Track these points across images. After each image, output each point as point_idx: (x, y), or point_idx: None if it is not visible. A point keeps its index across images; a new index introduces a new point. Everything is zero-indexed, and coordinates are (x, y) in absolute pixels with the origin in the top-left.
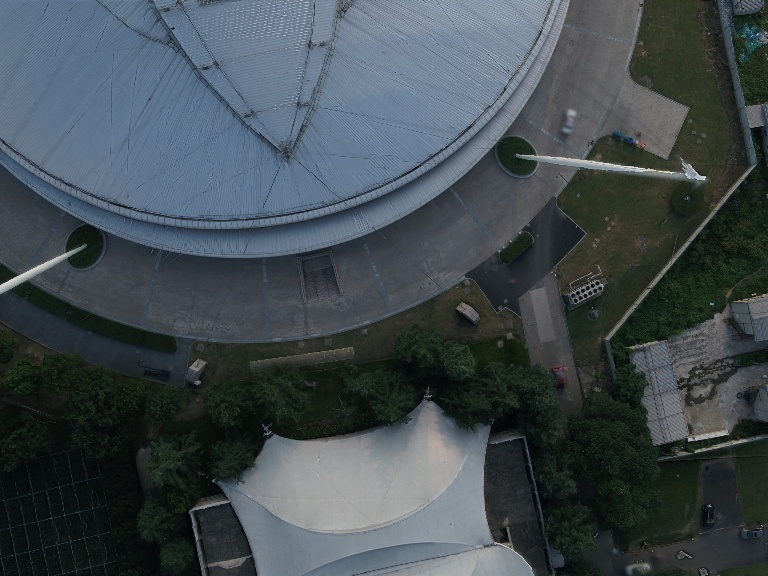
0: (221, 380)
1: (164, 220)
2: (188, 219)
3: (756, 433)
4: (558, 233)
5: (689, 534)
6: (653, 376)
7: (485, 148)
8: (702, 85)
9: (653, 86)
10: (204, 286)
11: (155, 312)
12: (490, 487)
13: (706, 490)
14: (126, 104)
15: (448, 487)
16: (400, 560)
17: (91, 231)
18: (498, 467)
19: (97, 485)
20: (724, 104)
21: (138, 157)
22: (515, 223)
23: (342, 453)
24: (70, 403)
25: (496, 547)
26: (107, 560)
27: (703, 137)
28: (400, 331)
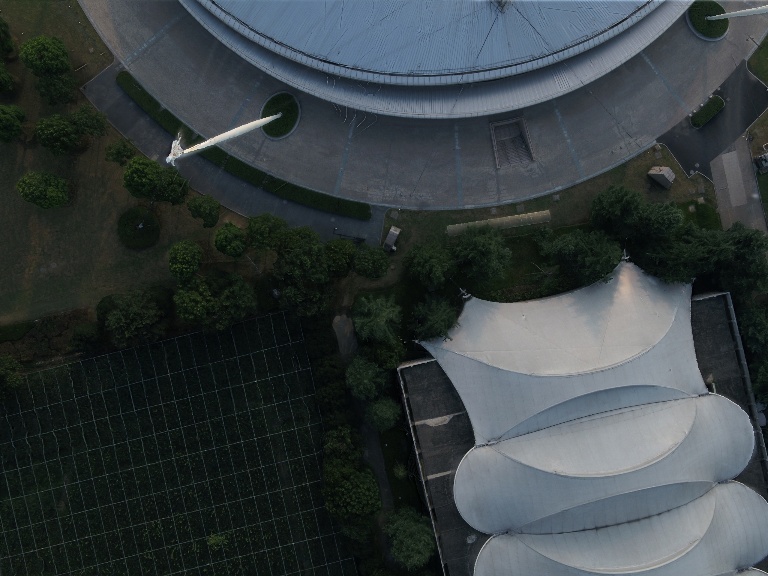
0: None
1: (373, 77)
2: (397, 75)
3: None
4: (749, 96)
5: None
6: None
7: (685, 5)
8: None
9: None
10: (397, 154)
11: (349, 180)
12: (694, 344)
13: None
14: None
15: (666, 334)
16: (624, 403)
17: (287, 99)
18: (701, 324)
19: (298, 349)
20: None
21: (353, 10)
22: (706, 87)
23: (546, 311)
24: (282, 260)
25: (711, 396)
26: (311, 422)
27: None
28: None
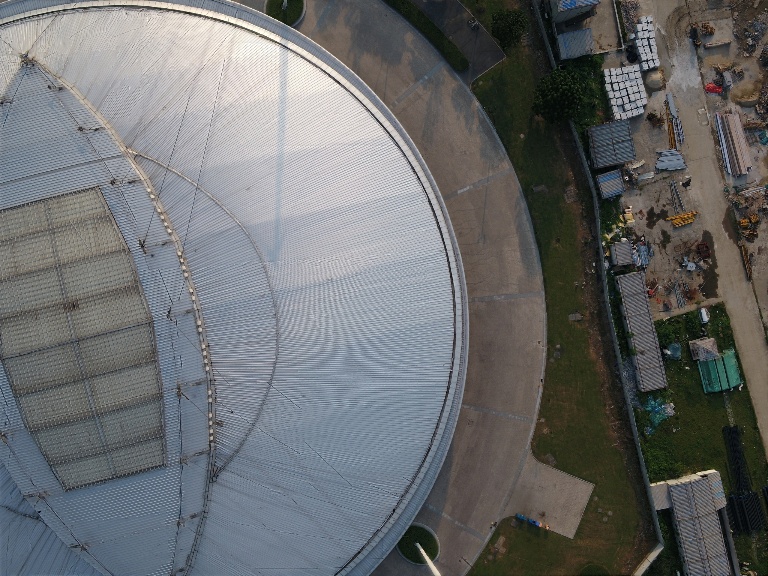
0: None
1: None
2: None
3: None
4: None
5: None
6: None
7: (379, 558)
8: (607, 461)
9: (556, 464)
10: None
11: None
12: None
13: None
14: (0, 569)
15: None
16: None
17: None
18: None
19: None
20: (630, 479)
21: None
22: None
23: None
24: None
25: None
26: None
27: (609, 515)
28: None
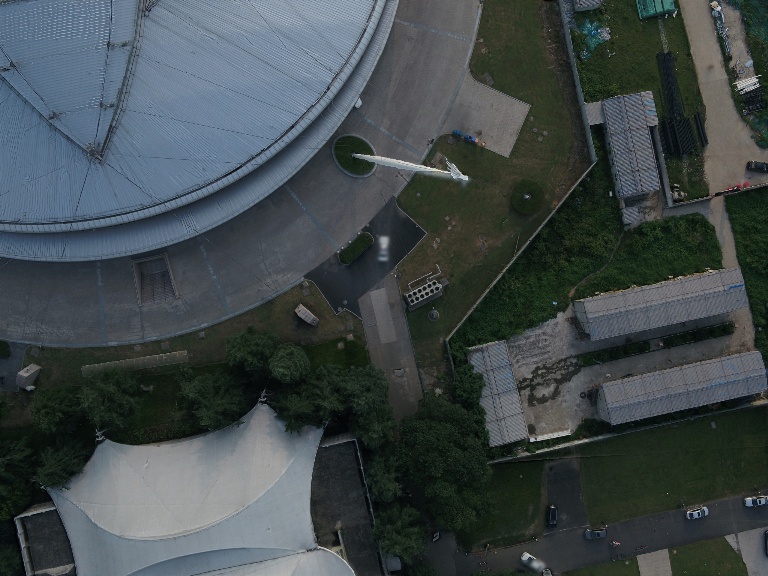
0: (56, 385)
1: None
2: (5, 223)
3: (599, 433)
4: (398, 233)
5: (533, 535)
6: (491, 376)
7: (314, 148)
8: (543, 82)
9: (494, 84)
10: (38, 290)
11: None
12: (322, 490)
13: (550, 490)
14: None
15: (267, 491)
16: (214, 566)
17: None
18: (330, 470)
19: None
20: (566, 101)
21: None
22: (354, 223)
23: (171, 458)
24: None
25: (319, 551)
26: None
27: (544, 135)
28: (234, 334)
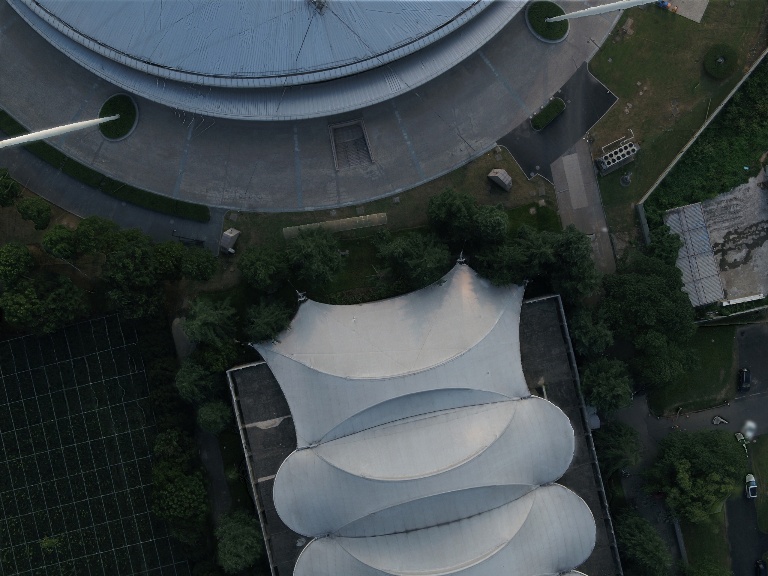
0: None
1: (197, 79)
2: (221, 77)
3: None
4: (590, 99)
5: (725, 399)
6: (688, 238)
7: (516, 7)
8: None
9: None
10: (236, 156)
11: (188, 182)
12: (525, 347)
13: (741, 355)
14: None
15: (485, 337)
16: (438, 406)
17: (123, 101)
18: (533, 327)
19: (134, 352)
20: None
21: (171, 12)
22: (546, 89)
23: (377, 314)
24: (108, 263)
25: (533, 399)
26: (146, 425)
27: None
28: None
